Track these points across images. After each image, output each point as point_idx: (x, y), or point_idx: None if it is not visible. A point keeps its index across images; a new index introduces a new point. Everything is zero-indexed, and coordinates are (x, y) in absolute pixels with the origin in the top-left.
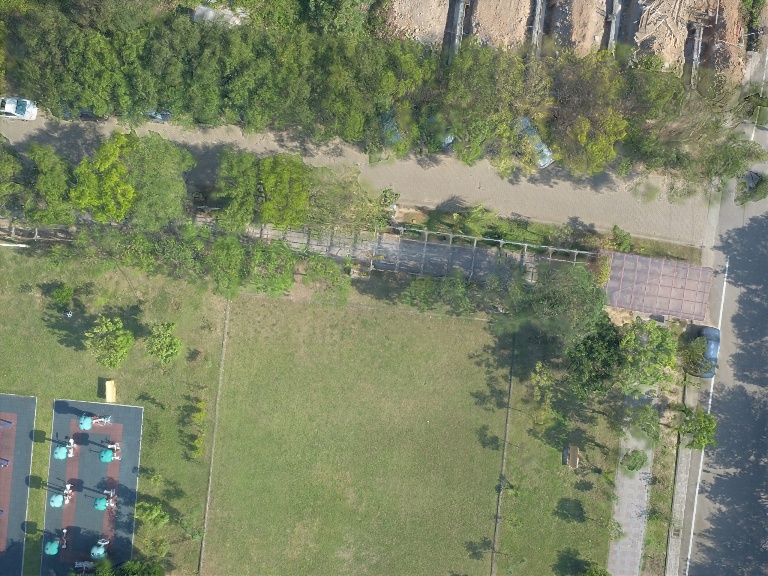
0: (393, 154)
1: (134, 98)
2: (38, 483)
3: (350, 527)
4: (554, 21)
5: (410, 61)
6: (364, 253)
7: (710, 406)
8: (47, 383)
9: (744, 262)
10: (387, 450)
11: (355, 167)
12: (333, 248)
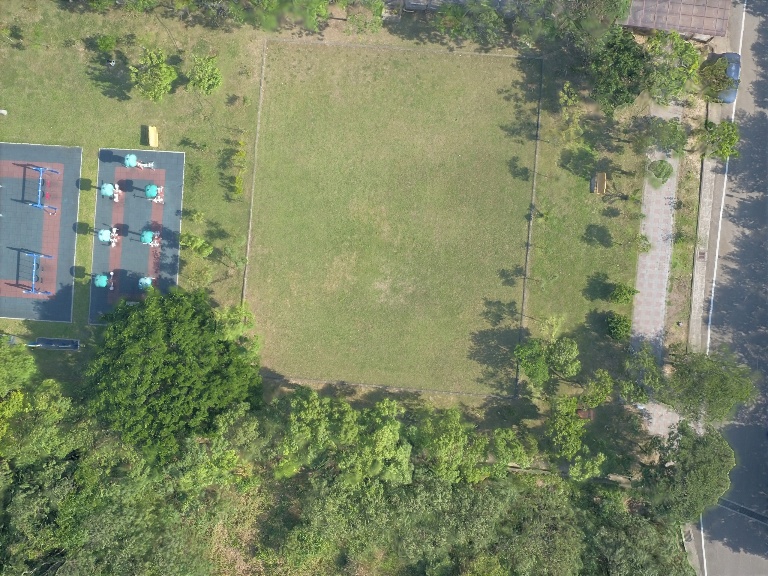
0: None
1: None
2: (85, 229)
3: (386, 259)
4: None
5: None
6: None
7: None
8: (92, 133)
9: None
10: (421, 184)
11: None
12: None
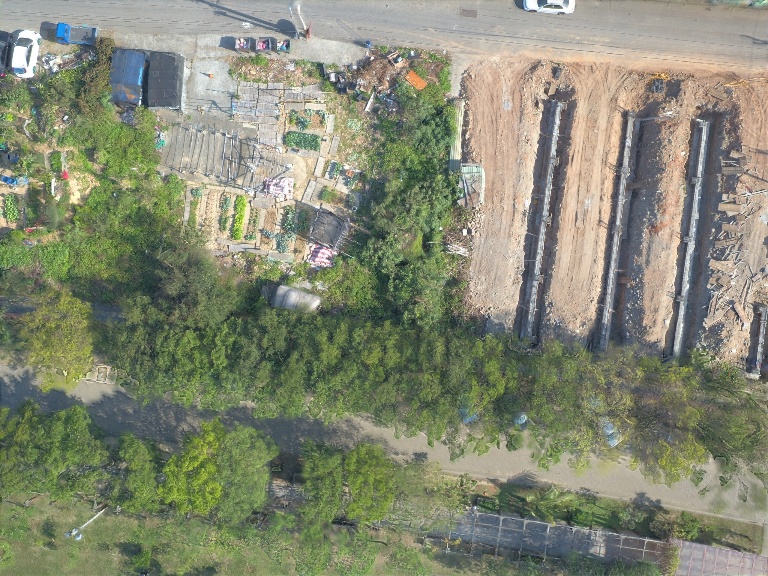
0: (466, 428)
1: (220, 390)
2: None
3: None
4: (624, 301)
5: (493, 371)
6: (440, 536)
7: None
8: None
9: None
10: None
11: (436, 465)
12: None
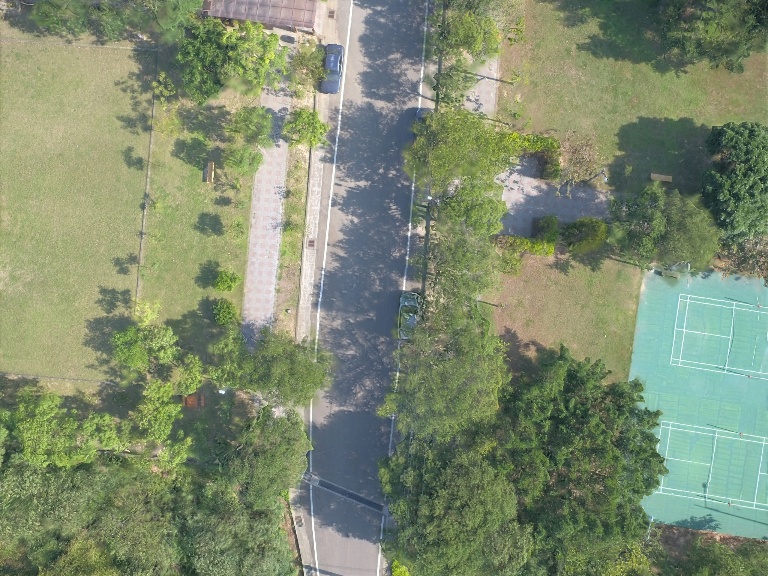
0: None
1: None
2: None
3: (6, 248)
4: None
5: None
6: None
7: (340, 122)
8: None
9: None
10: (40, 174)
11: None
12: None
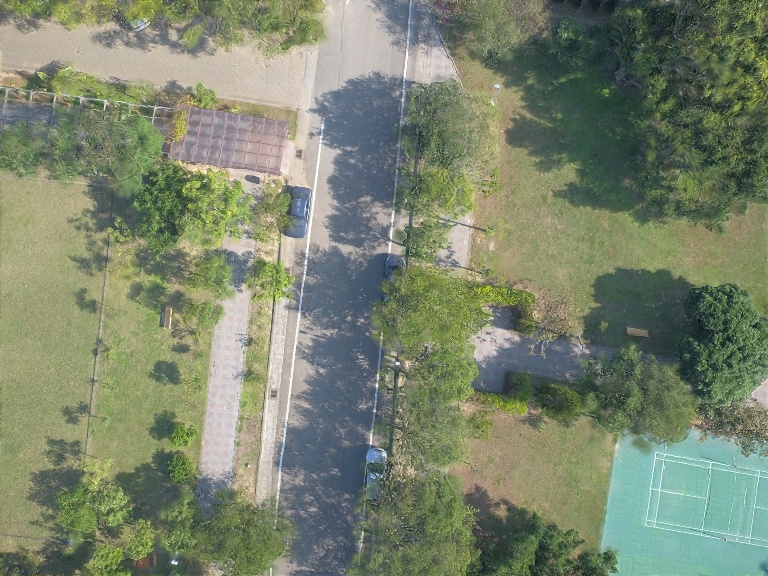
0: None
1: None
2: None
3: None
4: None
5: None
6: None
7: (306, 267)
8: None
9: (339, 124)
10: None
11: None
12: None
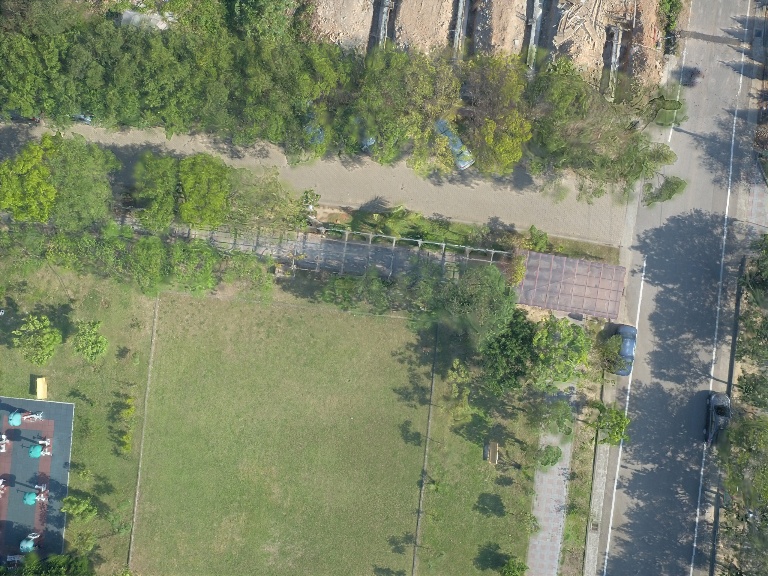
0: None
1: (59, 101)
2: None
3: (275, 521)
4: (475, 25)
5: (325, 65)
6: (286, 253)
7: (628, 403)
8: None
9: (661, 261)
10: (312, 446)
11: (273, 168)
12: (259, 248)
